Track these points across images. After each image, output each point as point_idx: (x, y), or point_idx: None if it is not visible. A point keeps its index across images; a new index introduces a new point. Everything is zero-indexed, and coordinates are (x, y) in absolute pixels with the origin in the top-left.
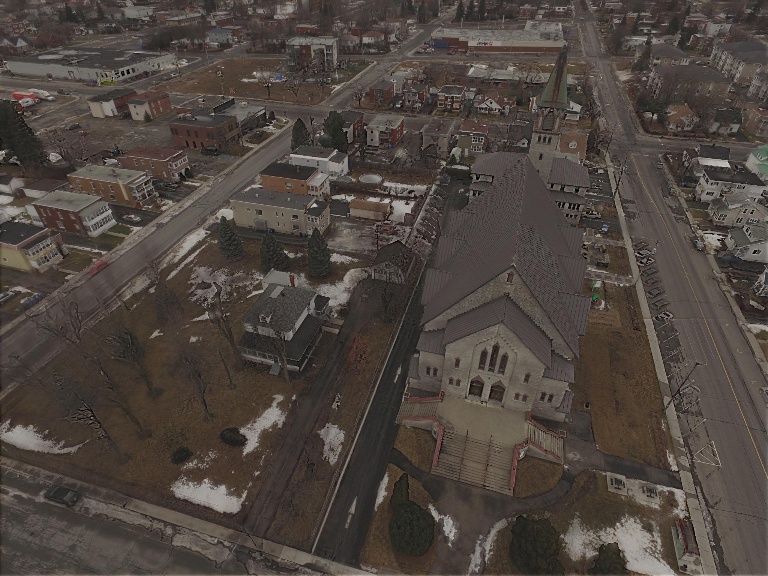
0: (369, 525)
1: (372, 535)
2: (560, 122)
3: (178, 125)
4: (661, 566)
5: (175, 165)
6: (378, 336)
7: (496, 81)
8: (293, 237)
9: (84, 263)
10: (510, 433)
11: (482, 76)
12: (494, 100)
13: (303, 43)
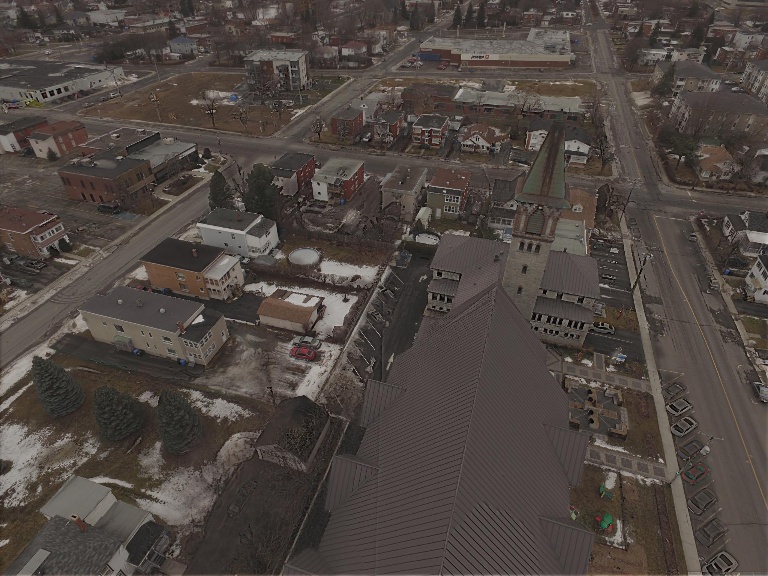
0: None
1: None
2: (554, 225)
3: (69, 174)
4: None
5: (41, 238)
6: None
7: (488, 107)
8: (168, 364)
9: None
10: None
11: (471, 101)
12: (481, 135)
13: (265, 58)
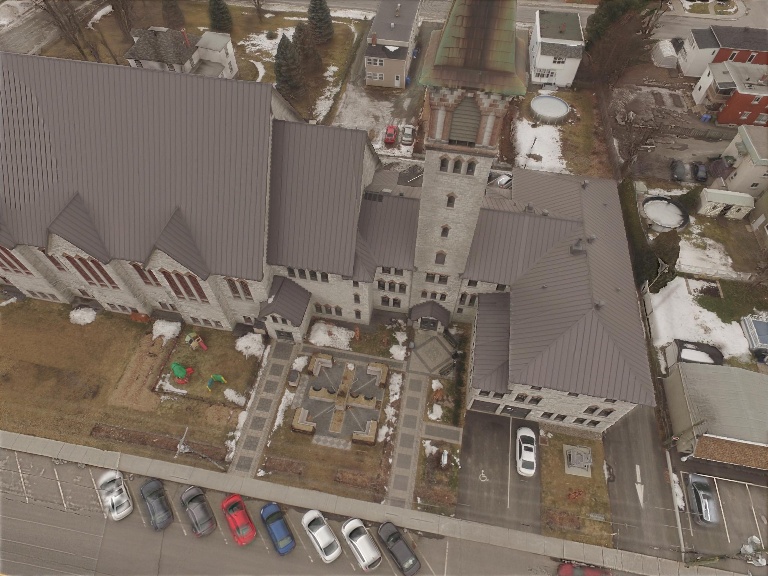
0: None
1: None
2: (431, 115)
3: None
4: None
5: None
6: None
7: None
8: None
9: None
10: None
11: None
12: None
13: None
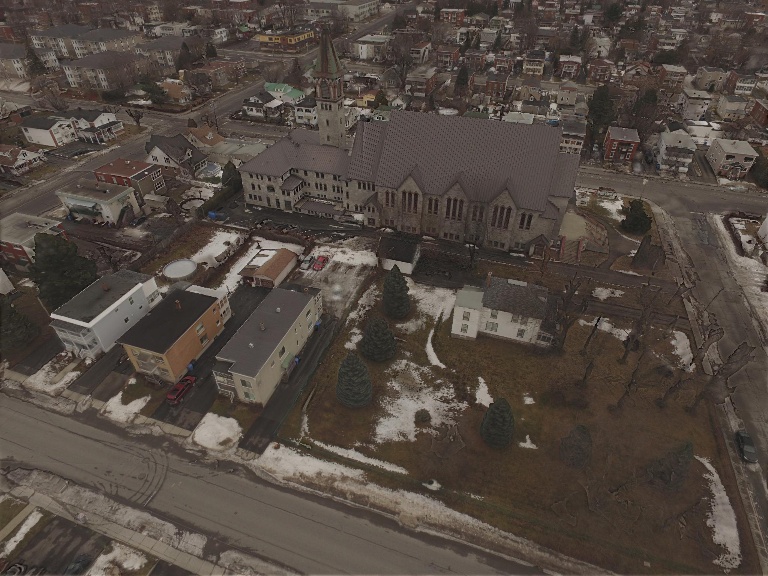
0: (653, 278)
1: (658, 277)
2: None
3: None
4: (618, 202)
5: None
6: (494, 272)
7: None
8: (316, 338)
9: None
10: (577, 219)
11: None
12: None
13: None
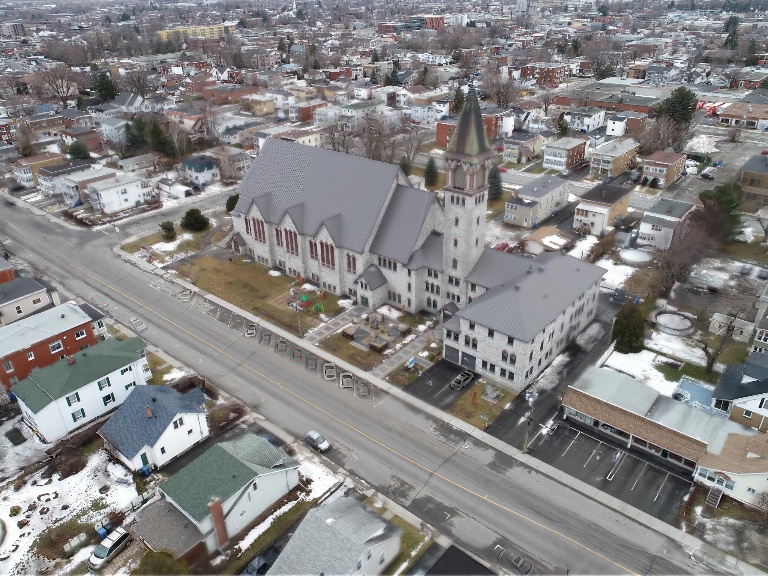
0: None
1: None
2: None
3: None
4: None
5: (647, 168)
6: None
7: None
8: None
9: (509, 167)
10: None
11: None
12: None
13: None
